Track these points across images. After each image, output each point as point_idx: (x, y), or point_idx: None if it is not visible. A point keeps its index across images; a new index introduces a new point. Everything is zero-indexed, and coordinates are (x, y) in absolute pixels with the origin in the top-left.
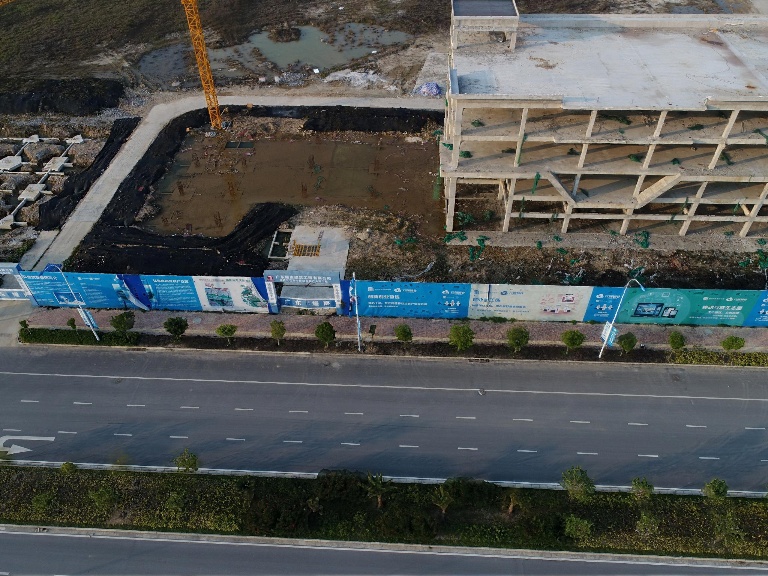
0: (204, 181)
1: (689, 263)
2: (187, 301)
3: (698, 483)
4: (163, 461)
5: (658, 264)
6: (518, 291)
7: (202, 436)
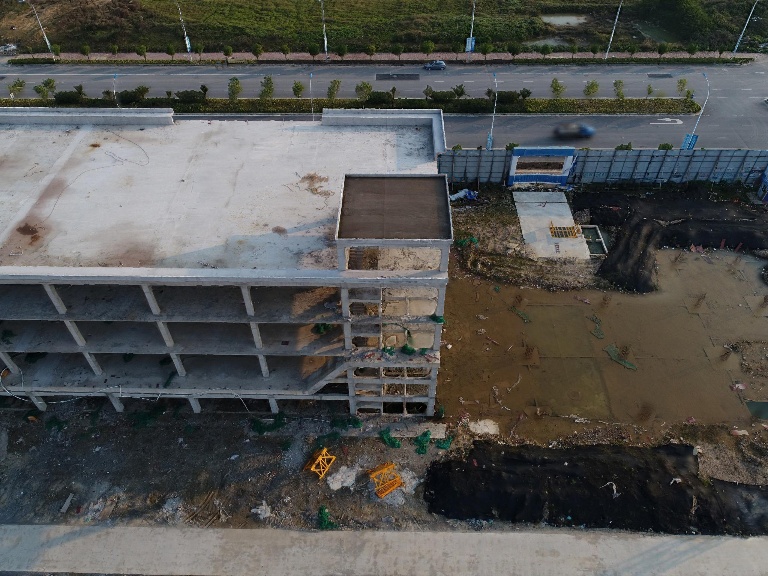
0: (757, 328)
1: None
2: (634, 174)
3: (294, 118)
4: (580, 118)
5: None
6: None
7: (566, 127)
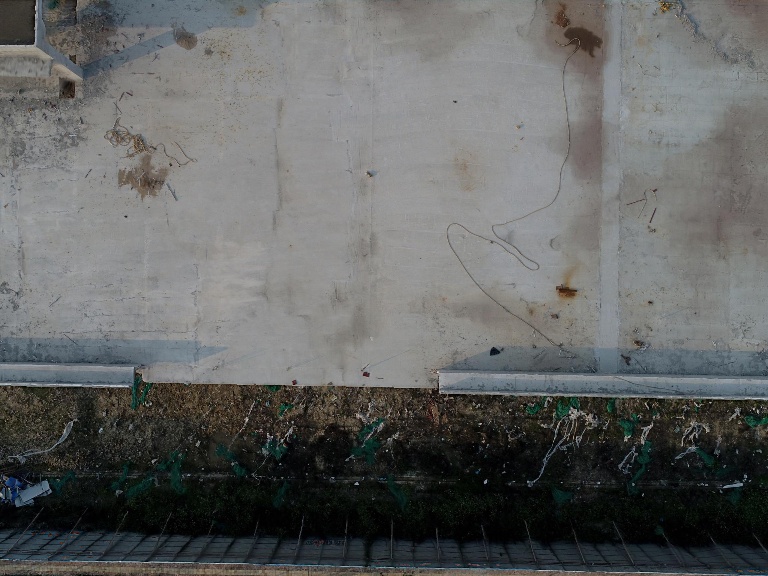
0: None
1: (454, 408)
2: None
3: None
4: None
5: (407, 412)
6: (154, 557)
7: None
